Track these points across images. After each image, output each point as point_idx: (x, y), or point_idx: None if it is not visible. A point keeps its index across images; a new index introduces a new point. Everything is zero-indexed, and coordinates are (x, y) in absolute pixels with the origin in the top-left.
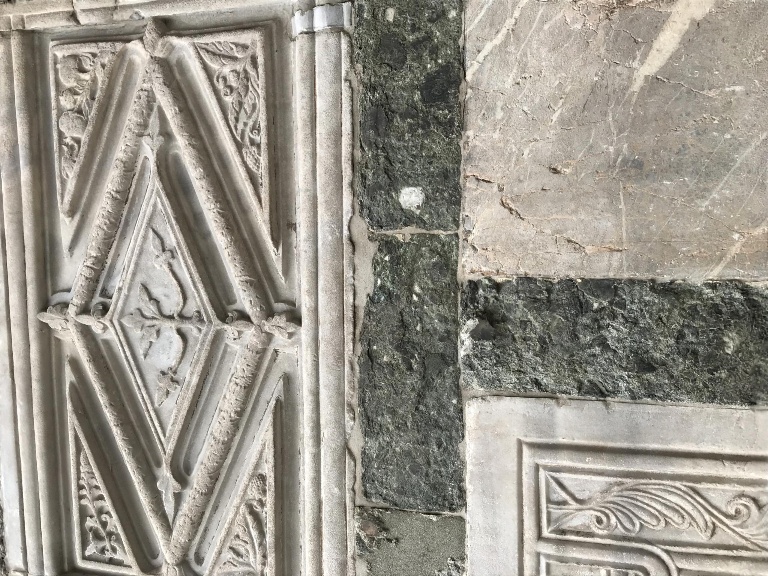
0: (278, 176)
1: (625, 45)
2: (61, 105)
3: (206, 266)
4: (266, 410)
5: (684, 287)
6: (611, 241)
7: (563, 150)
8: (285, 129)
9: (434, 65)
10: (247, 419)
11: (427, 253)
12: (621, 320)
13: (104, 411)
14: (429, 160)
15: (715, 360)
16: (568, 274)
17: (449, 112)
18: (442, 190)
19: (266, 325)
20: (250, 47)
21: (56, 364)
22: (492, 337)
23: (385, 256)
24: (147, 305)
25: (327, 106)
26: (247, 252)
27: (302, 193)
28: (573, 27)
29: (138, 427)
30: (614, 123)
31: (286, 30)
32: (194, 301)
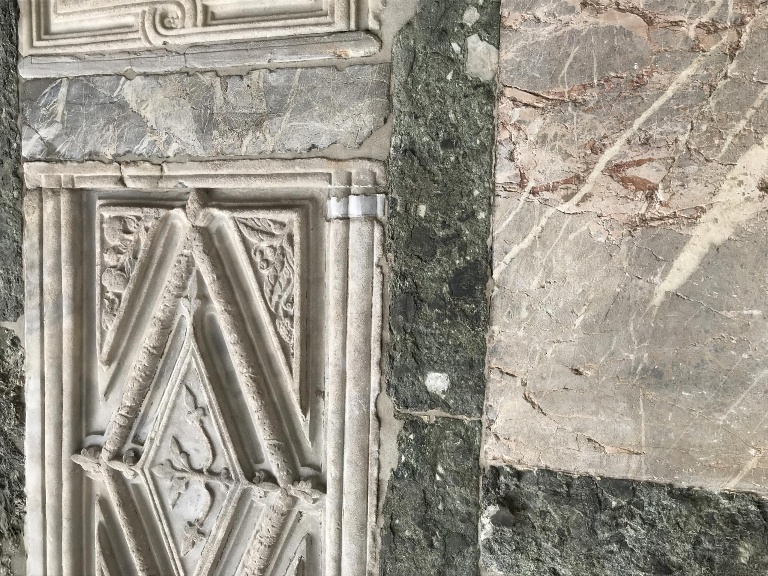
0: (309, 346)
1: (647, 262)
2: (105, 261)
3: (236, 424)
4: (288, 567)
5: (701, 494)
6: (630, 444)
7: (585, 353)
8: (317, 302)
9: (462, 261)
10: (269, 575)
11: (451, 436)
12: (639, 521)
13: (131, 553)
14: (455, 349)
15: (731, 569)
16: (588, 471)
17: (476, 306)
18: (467, 379)
19: (292, 489)
20: (287, 225)
21: (86, 502)
22: (512, 524)
23: (410, 434)
24: (178, 458)
25: (359, 289)
26: (276, 415)
27: (332, 367)
28: (597, 240)
29: (163, 572)
30: (635, 333)
31: (322, 210)
32: (223, 458)
